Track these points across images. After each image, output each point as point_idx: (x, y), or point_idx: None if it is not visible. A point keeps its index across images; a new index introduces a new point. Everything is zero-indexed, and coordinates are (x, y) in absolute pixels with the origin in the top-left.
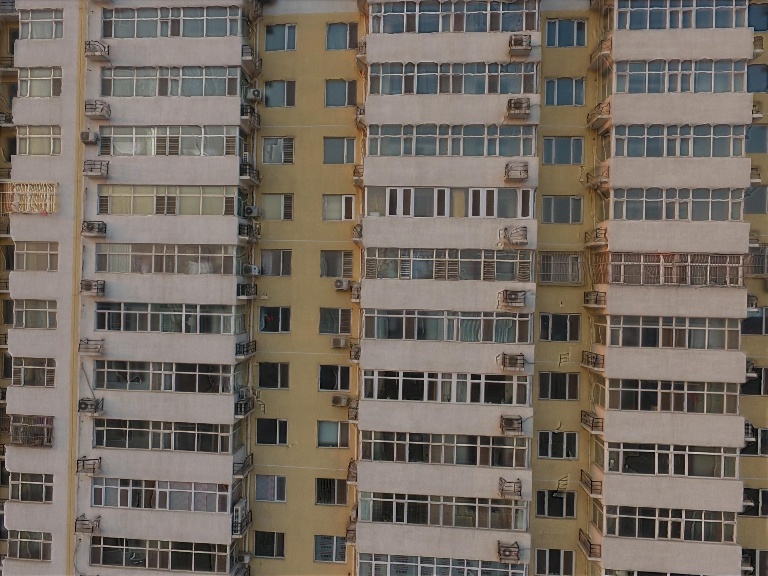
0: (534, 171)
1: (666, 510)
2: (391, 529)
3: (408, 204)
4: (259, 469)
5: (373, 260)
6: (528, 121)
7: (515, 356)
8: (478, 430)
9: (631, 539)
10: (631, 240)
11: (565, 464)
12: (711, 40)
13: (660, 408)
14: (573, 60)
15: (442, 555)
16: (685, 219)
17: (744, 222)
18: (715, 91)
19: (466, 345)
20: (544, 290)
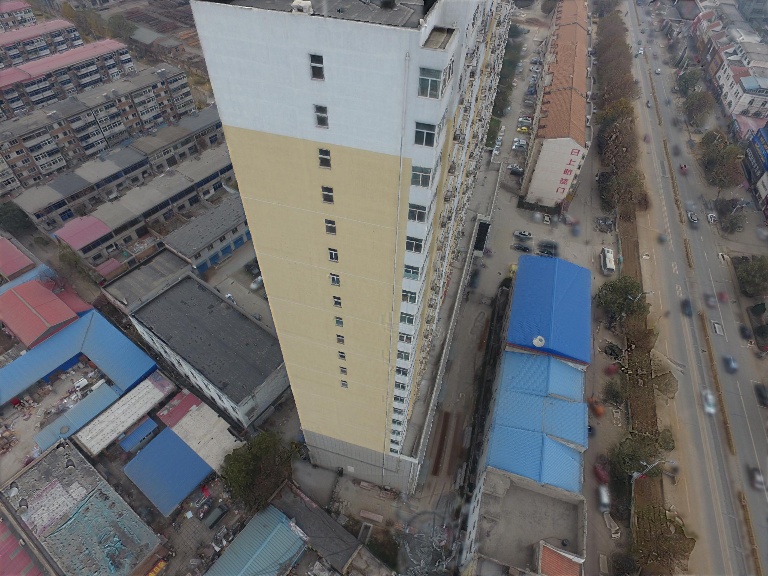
0: None
1: None
2: None
3: None
4: None
5: None
6: None
7: None
8: None
9: None
10: None
11: None
12: None
13: None
14: None
15: None
16: None
17: None
18: None
19: None
20: None
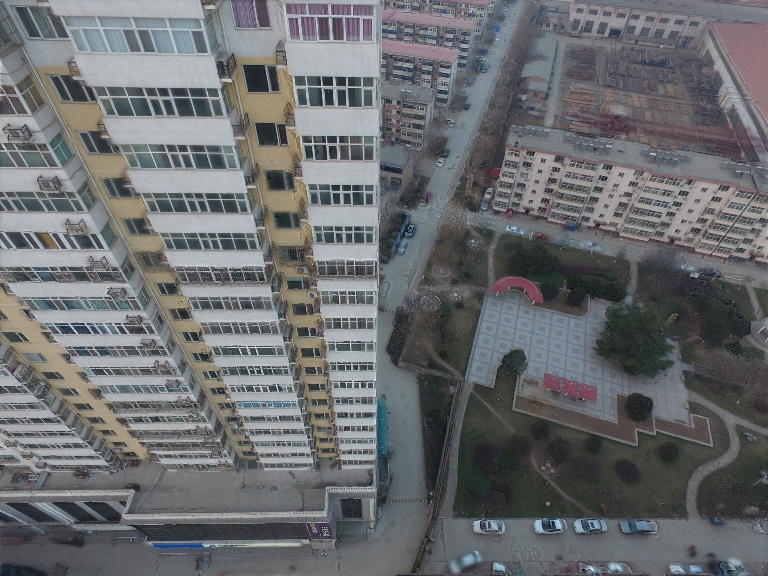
0: (91, 223)
1: (251, 366)
2: (108, 378)
3: (7, 242)
4: (21, 351)
5: (6, 273)
6: (66, 190)
7: (132, 320)
8: (132, 345)
9: (236, 376)
10: (184, 262)
11: (202, 344)
12: (195, 129)
13: (234, 333)
14: (93, 116)
15: (141, 384)
16: (219, 249)
17: (277, 234)
18: (214, 167)
19: (102, 312)
20: (150, 273)
